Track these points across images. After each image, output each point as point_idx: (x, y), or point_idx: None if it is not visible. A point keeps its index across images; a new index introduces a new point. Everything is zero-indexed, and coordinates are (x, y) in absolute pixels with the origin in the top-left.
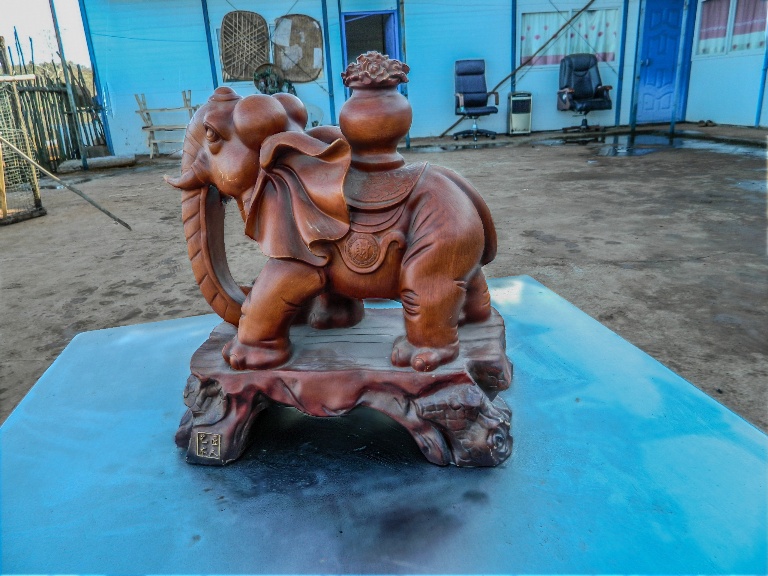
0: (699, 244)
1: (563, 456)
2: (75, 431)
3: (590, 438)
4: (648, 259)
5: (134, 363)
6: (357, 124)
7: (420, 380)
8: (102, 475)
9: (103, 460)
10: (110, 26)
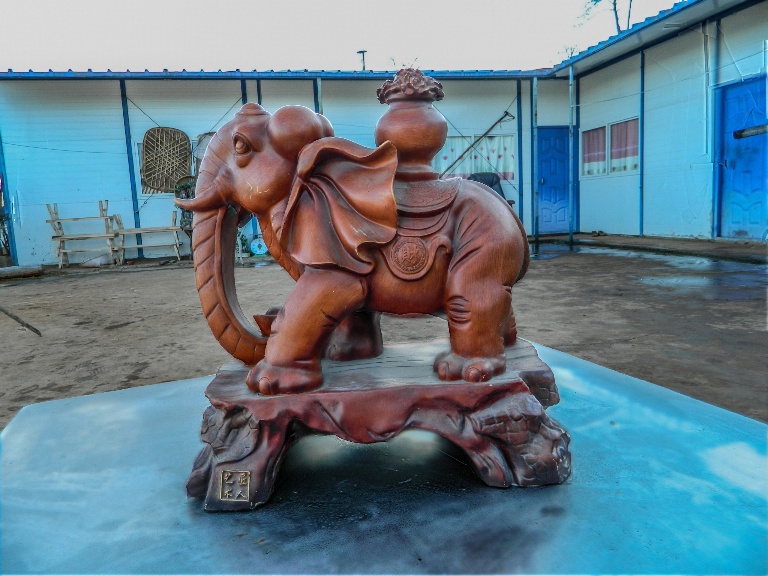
0: (622, 329)
1: (625, 469)
2: (50, 494)
3: (643, 452)
4: (581, 343)
5: (105, 426)
6: (399, 132)
7: (476, 391)
8: (99, 533)
9: (96, 519)
10: (26, 137)
